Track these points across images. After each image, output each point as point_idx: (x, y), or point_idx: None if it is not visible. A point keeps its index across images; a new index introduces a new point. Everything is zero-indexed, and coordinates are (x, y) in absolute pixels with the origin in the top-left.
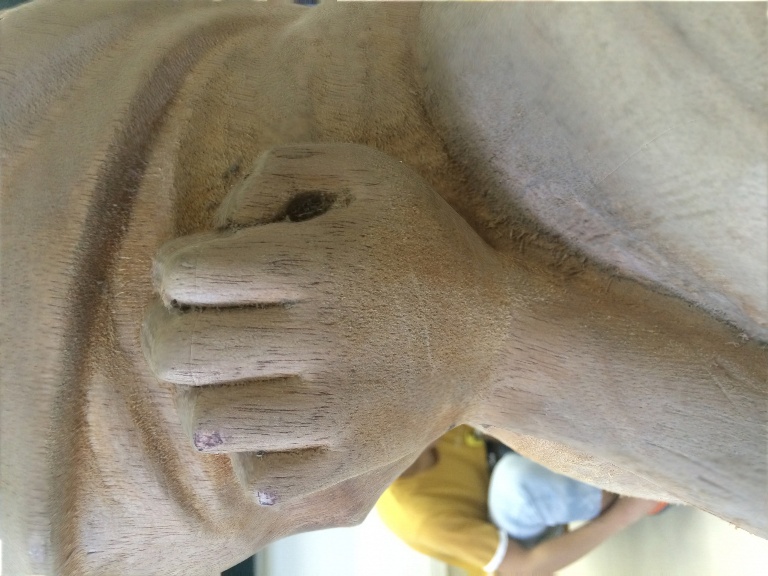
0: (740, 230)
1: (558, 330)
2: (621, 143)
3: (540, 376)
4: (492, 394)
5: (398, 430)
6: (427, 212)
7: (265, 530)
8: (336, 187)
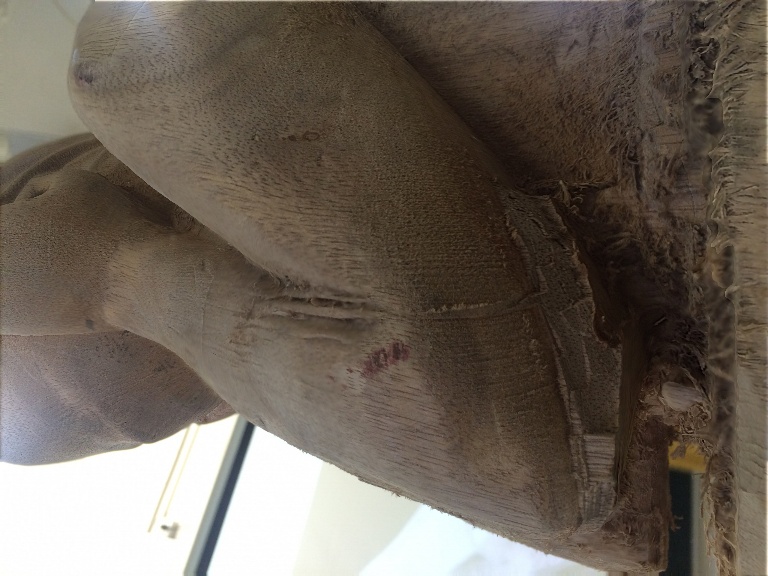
0: None
1: (140, 255)
2: None
3: (128, 285)
4: (106, 298)
5: (27, 303)
6: (80, 192)
7: (43, 402)
8: (47, 186)
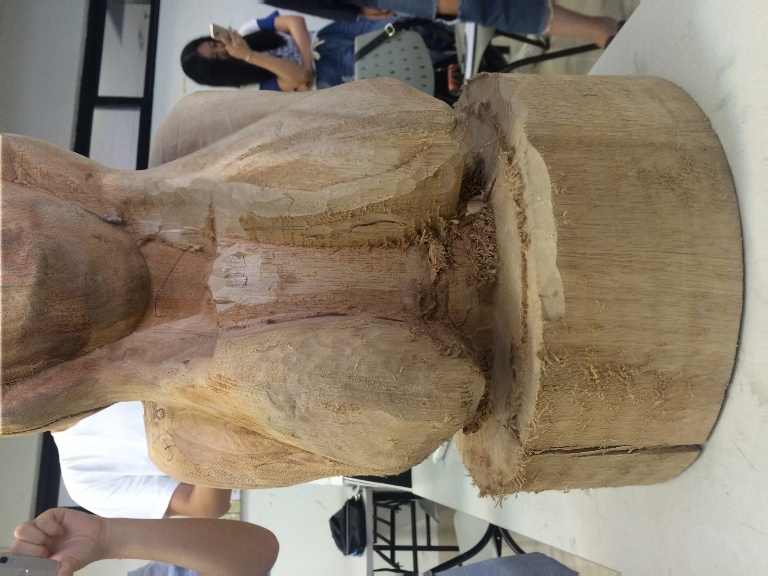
0: (184, 116)
1: None
2: None
3: None
4: None
5: None
6: None
7: None
8: None
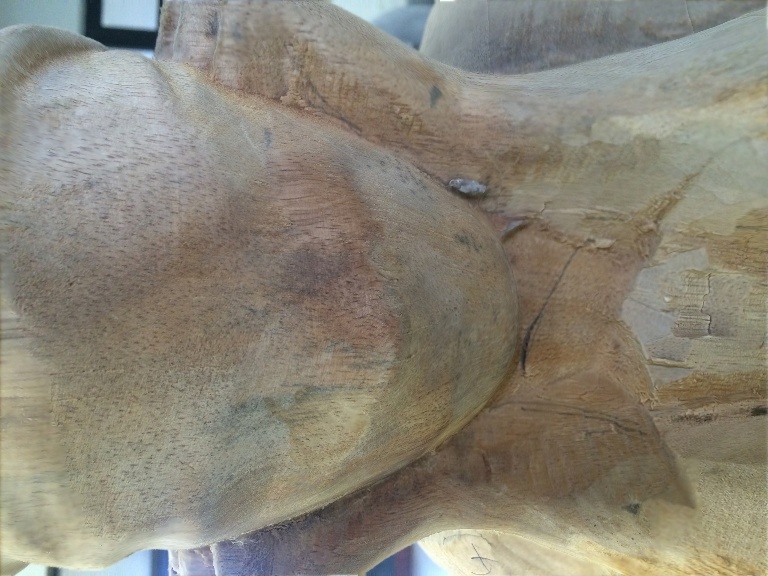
0: None
1: None
2: (479, 1)
3: None
4: (468, 82)
5: None
6: None
7: (246, 182)
8: None
